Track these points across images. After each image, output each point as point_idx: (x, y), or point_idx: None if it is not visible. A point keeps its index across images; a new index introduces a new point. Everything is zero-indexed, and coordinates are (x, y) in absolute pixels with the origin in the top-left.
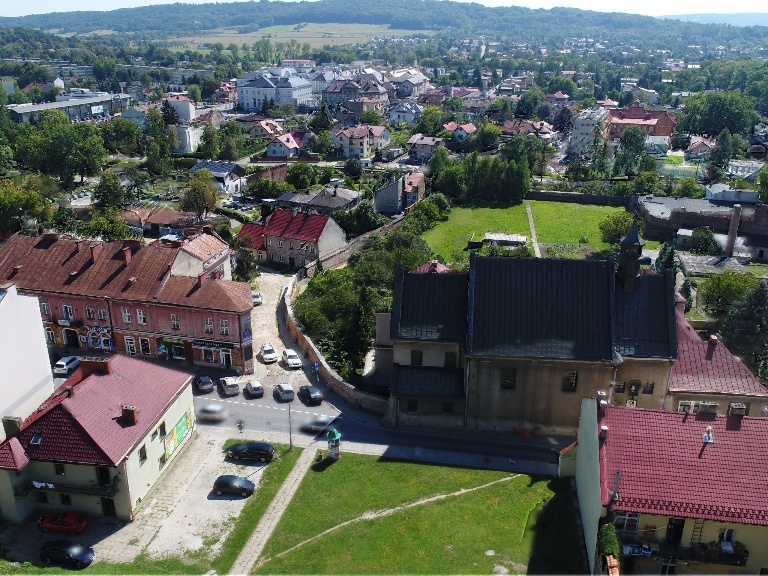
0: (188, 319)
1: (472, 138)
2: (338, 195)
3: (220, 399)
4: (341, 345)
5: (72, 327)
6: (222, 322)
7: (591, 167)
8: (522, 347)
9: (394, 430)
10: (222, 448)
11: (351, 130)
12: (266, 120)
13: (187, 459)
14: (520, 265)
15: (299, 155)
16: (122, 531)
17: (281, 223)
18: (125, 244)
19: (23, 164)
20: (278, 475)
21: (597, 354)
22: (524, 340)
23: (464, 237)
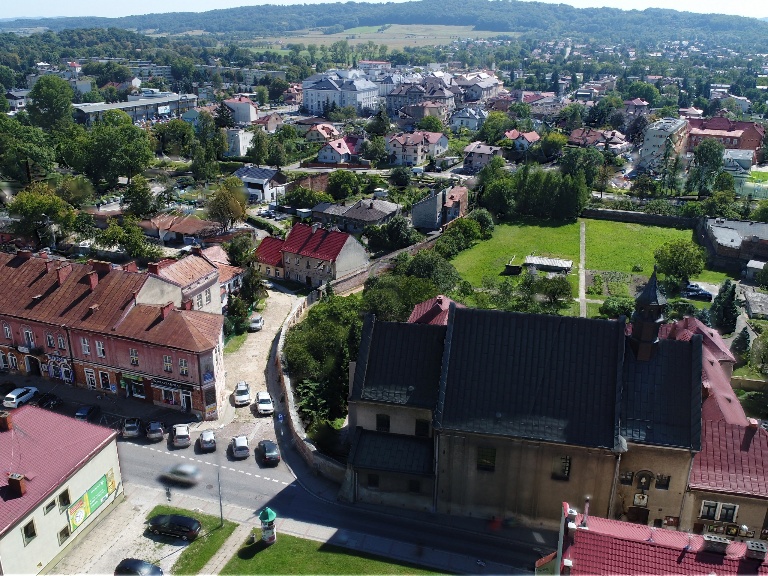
0: (147, 355)
1: (534, 147)
2: (375, 207)
3: (166, 451)
4: (323, 389)
5: (32, 355)
6: (181, 361)
7: (659, 183)
8: (503, 423)
9: (350, 507)
10: (146, 517)
11: (405, 136)
12: (325, 123)
13: (103, 529)
14: (508, 321)
15: (351, 161)
16: None
17: (300, 239)
18: (94, 266)
19: (65, 166)
20: (196, 560)
21: (595, 438)
22: (506, 414)
23: (503, 259)
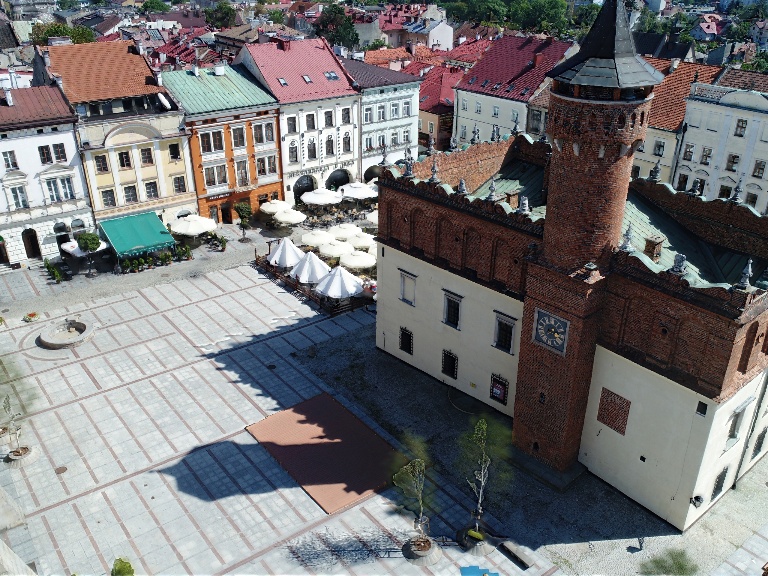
0: None
1: None
2: None
3: None
4: None
5: None
6: None
7: None
8: None
9: None
10: None
11: (765, 22)
12: None
13: None
14: None
15: (715, 40)
16: None
17: None
18: None
19: (510, 20)
20: None
21: None
22: None
23: None
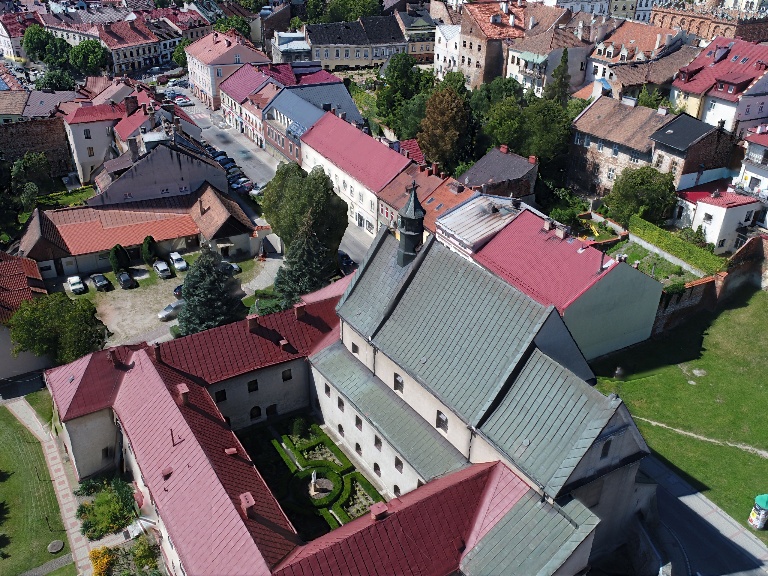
0: None
1: None
2: None
3: None
4: None
5: None
6: None
7: None
8: None
9: None
10: None
11: None
12: None
13: None
14: None
15: None
16: None
17: None
18: None
19: None
20: None
21: None
22: None
23: None
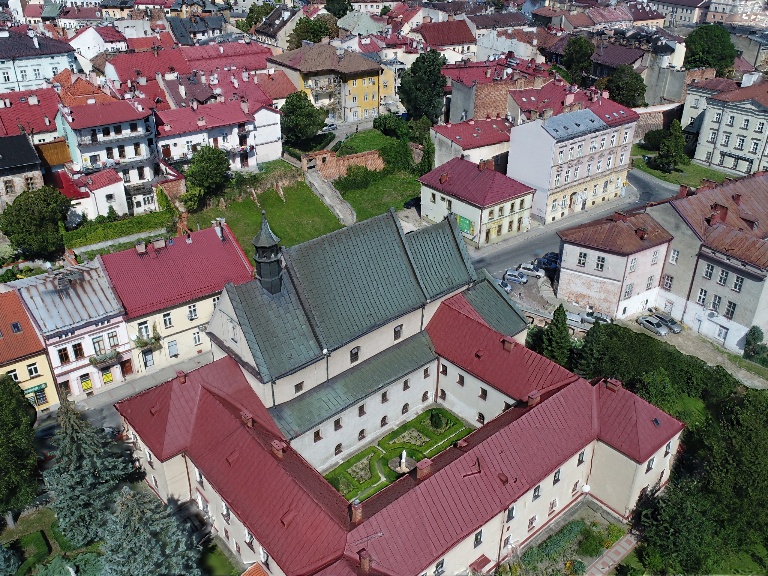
0: None
1: None
2: None
3: None
4: None
5: None
6: None
7: None
8: None
9: None
10: None
11: None
12: None
13: None
14: None
15: None
16: (418, 216)
17: None
18: None
19: None
20: None
21: None
22: None
23: None
